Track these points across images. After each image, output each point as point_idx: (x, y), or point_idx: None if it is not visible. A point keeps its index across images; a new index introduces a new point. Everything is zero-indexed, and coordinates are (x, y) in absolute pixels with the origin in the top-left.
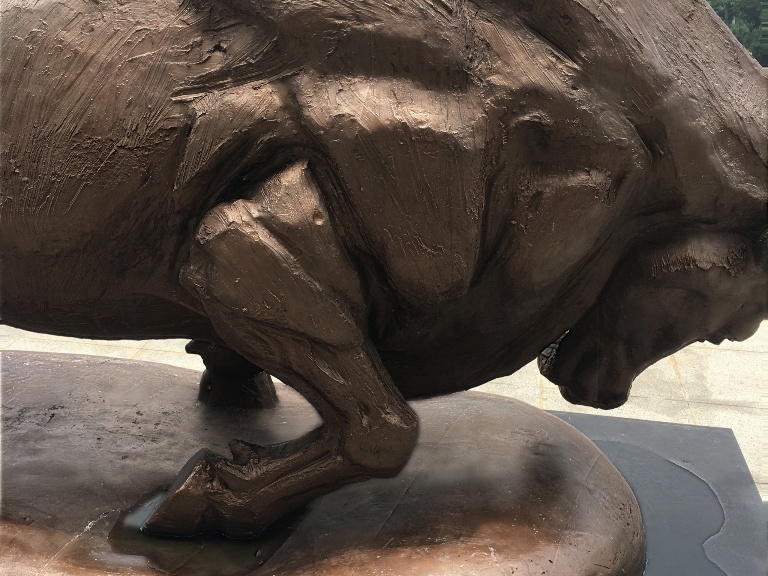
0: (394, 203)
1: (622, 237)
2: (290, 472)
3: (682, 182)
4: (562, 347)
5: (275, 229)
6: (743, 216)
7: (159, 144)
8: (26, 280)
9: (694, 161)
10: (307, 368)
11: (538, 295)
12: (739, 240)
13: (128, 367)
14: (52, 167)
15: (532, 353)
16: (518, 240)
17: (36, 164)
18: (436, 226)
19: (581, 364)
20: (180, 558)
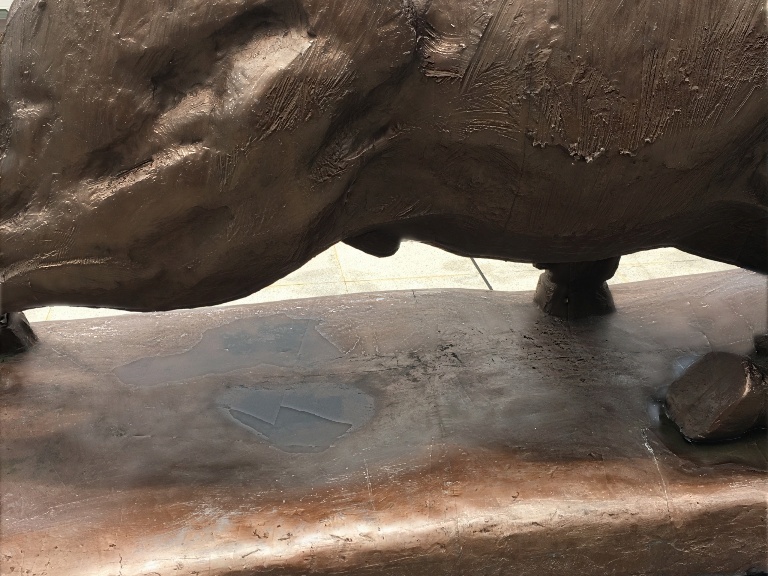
0: None
1: None
2: None
3: None
4: None
5: None
6: None
7: None
8: (640, 201)
9: None
10: None
11: None
12: None
13: (444, 296)
14: (725, 72)
15: None
16: None
17: (707, 70)
18: None
19: None
20: (756, 457)
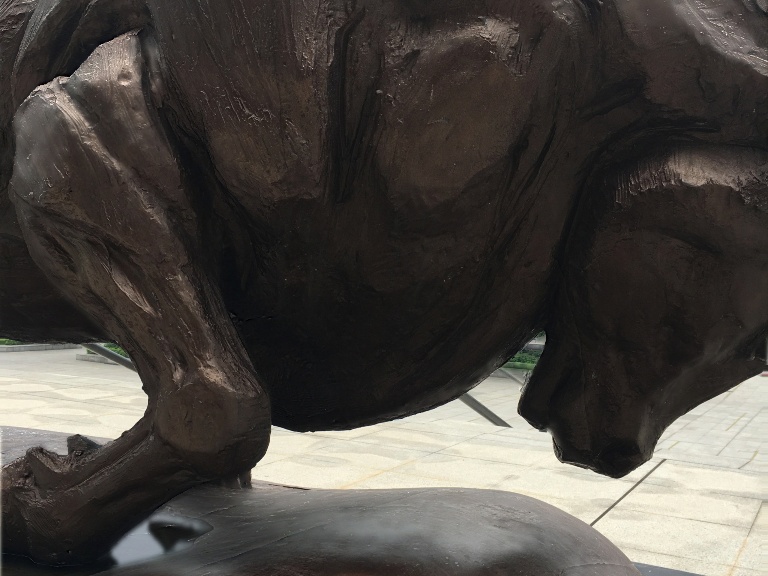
0: (210, 52)
1: (572, 151)
2: (105, 464)
3: (632, 40)
4: (539, 365)
5: (74, 91)
6: (759, 115)
7: (6, 32)
8: None
9: (649, 11)
10: (103, 284)
11: (448, 231)
12: (762, 159)
13: None
14: None
15: (471, 348)
16: (384, 115)
17: None
18: (260, 81)
19: (562, 387)
20: None
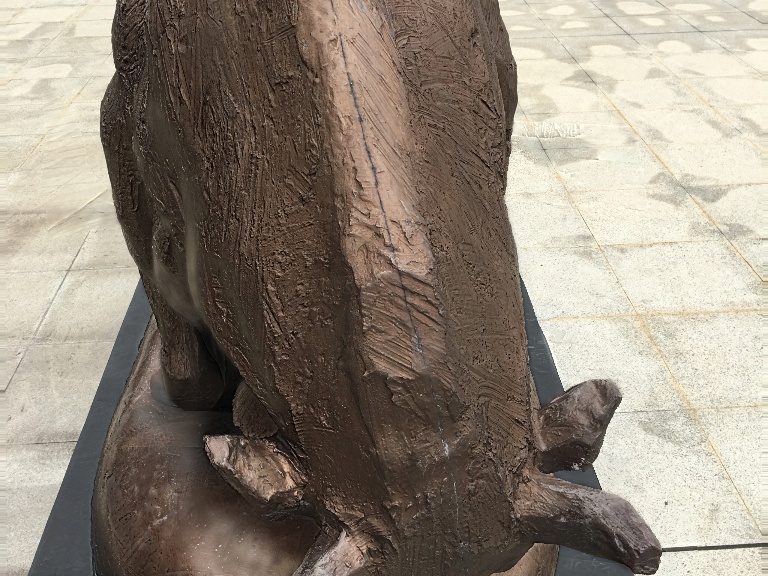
0: None
1: None
2: None
3: None
4: None
5: None
6: None
7: None
8: None
9: None
10: None
11: None
12: None
13: None
14: None
15: None
16: None
17: None
18: None
19: None
20: None
